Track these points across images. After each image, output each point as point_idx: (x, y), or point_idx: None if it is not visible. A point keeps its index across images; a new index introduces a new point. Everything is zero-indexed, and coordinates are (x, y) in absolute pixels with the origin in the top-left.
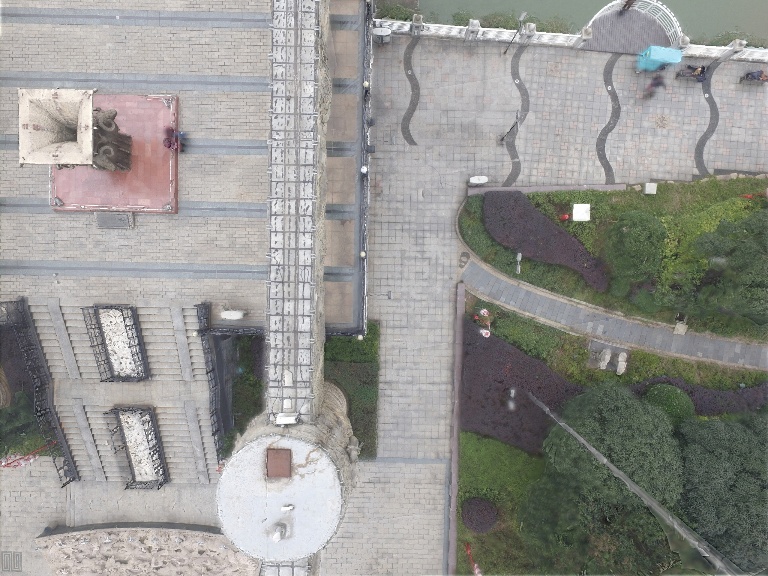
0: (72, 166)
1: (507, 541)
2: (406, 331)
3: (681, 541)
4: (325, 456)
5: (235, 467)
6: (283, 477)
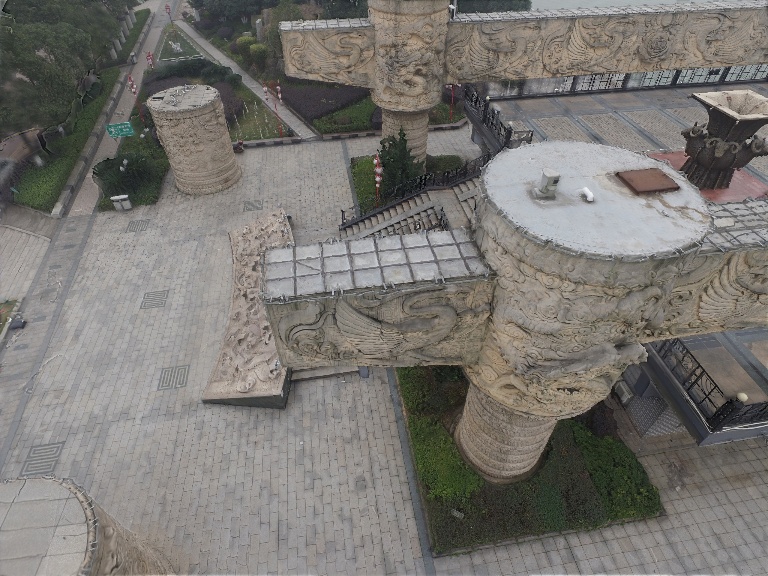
0: (698, 134)
1: None
2: (678, 571)
3: None
4: (705, 225)
5: (602, 150)
6: (628, 188)
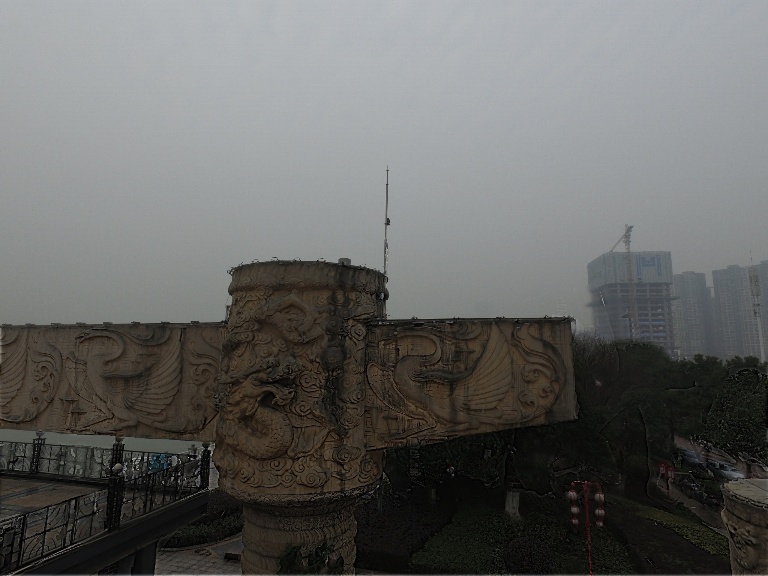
0: None
1: (567, 555)
2: None
3: (388, 262)
4: None
5: None
6: None
